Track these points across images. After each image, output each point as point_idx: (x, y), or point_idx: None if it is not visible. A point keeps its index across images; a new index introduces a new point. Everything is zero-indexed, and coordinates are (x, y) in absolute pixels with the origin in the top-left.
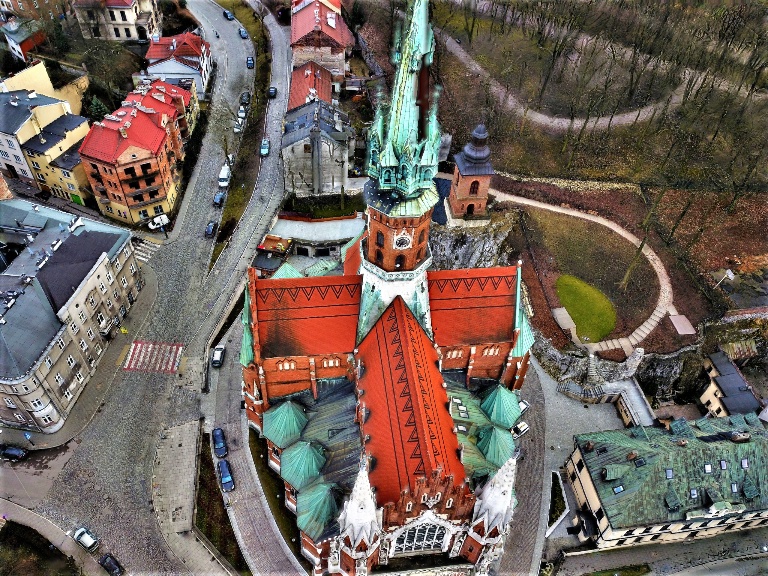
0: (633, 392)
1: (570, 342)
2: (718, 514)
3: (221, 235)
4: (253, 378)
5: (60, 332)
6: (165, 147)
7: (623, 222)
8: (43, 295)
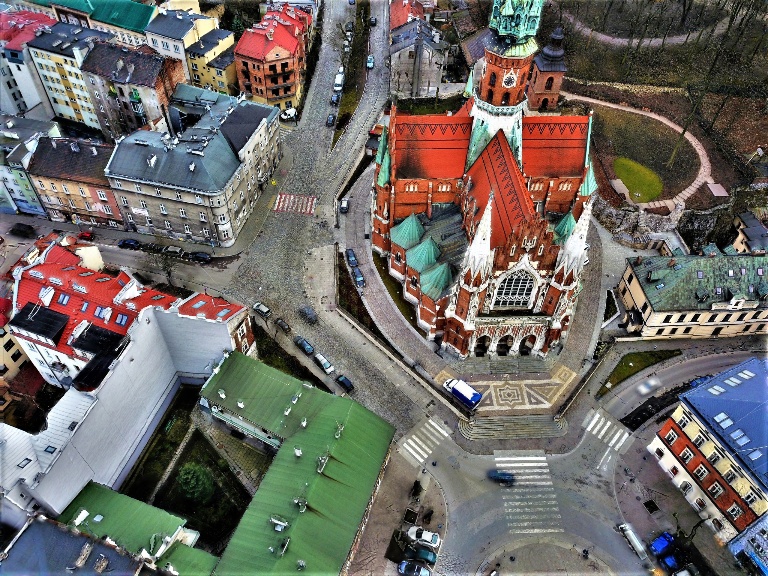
0: (674, 240)
1: (624, 202)
2: (737, 307)
3: (339, 124)
4: (385, 199)
5: (240, 167)
6: (297, 53)
7: (672, 117)
8: (226, 142)
